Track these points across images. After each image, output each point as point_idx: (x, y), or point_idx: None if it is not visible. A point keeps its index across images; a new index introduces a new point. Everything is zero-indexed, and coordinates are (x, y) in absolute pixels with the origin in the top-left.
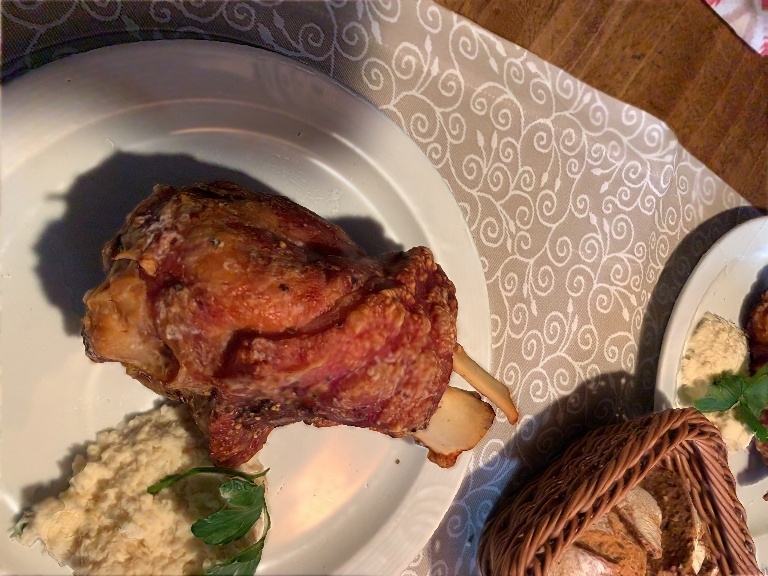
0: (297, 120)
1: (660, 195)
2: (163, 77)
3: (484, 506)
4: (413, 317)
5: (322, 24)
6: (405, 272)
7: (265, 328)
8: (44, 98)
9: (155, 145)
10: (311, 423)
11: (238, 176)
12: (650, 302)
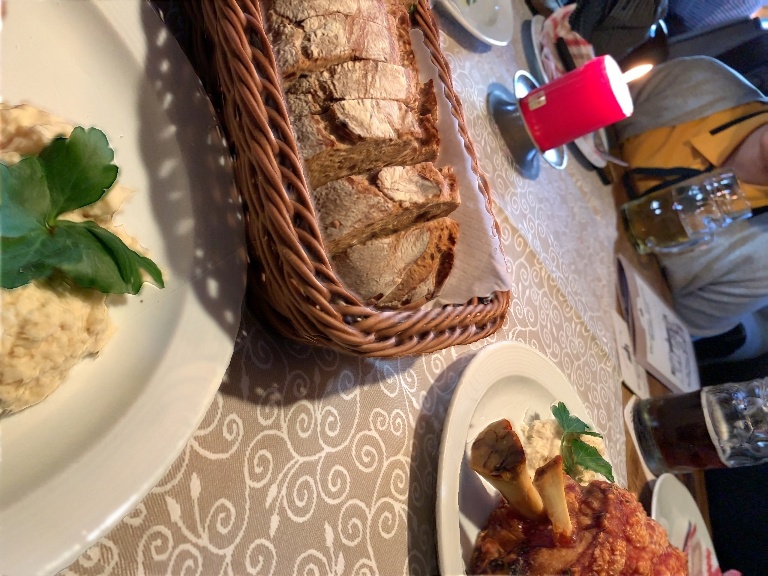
0: None
1: None
2: None
3: None
4: (650, 575)
5: None
6: None
7: None
8: None
9: None
10: None
11: None
12: None
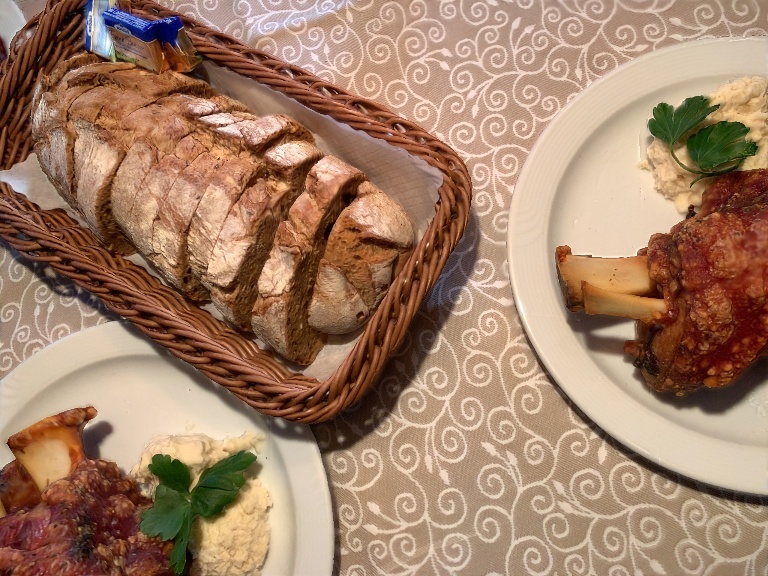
0: None
1: None
2: None
3: None
4: None
5: None
6: None
7: None
8: None
9: None
10: None
11: None
12: (337, 546)
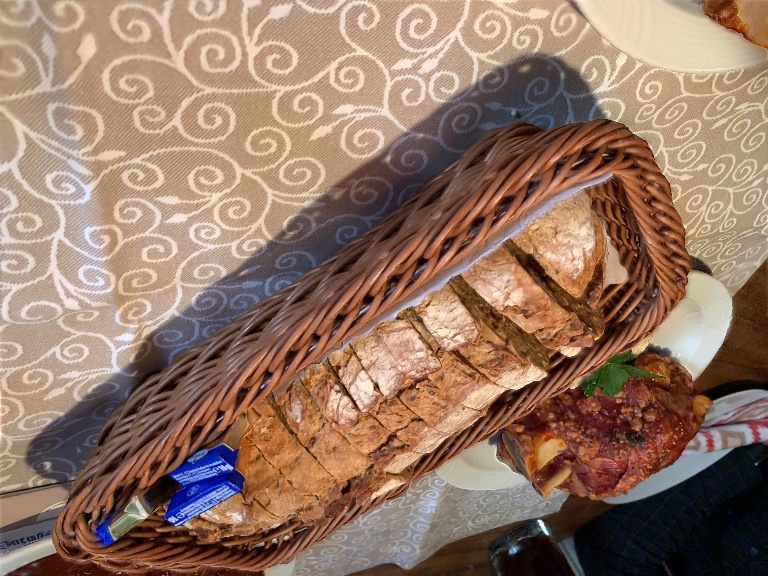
0: None
1: (765, 228)
2: None
3: (548, 122)
4: None
5: None
6: None
7: None
8: None
9: None
10: None
11: None
12: None
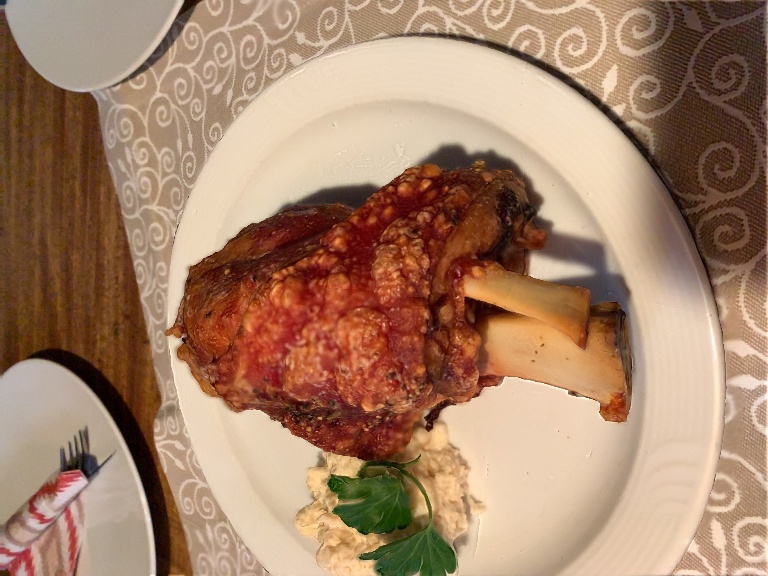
0: (321, 117)
1: None
2: (231, 167)
3: None
4: (318, 283)
5: (333, 1)
6: (329, 231)
7: (220, 352)
8: (192, 231)
9: (266, 212)
10: (477, 395)
11: (321, 194)
12: None
